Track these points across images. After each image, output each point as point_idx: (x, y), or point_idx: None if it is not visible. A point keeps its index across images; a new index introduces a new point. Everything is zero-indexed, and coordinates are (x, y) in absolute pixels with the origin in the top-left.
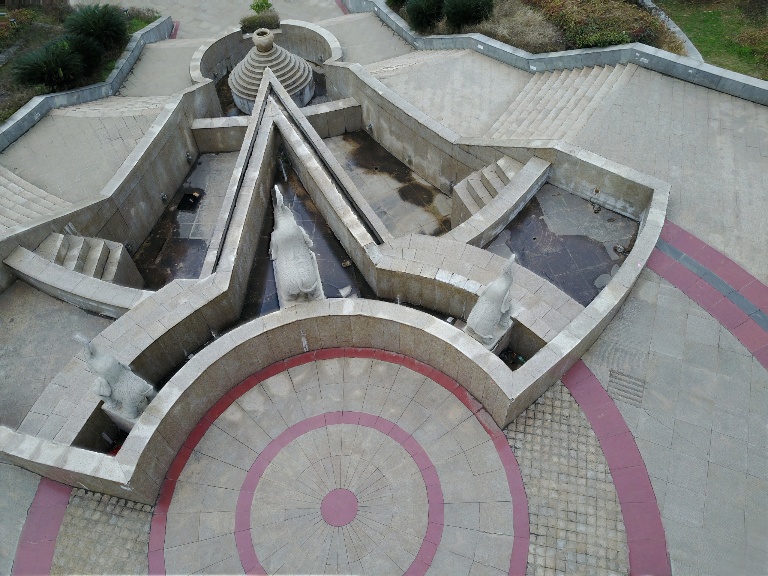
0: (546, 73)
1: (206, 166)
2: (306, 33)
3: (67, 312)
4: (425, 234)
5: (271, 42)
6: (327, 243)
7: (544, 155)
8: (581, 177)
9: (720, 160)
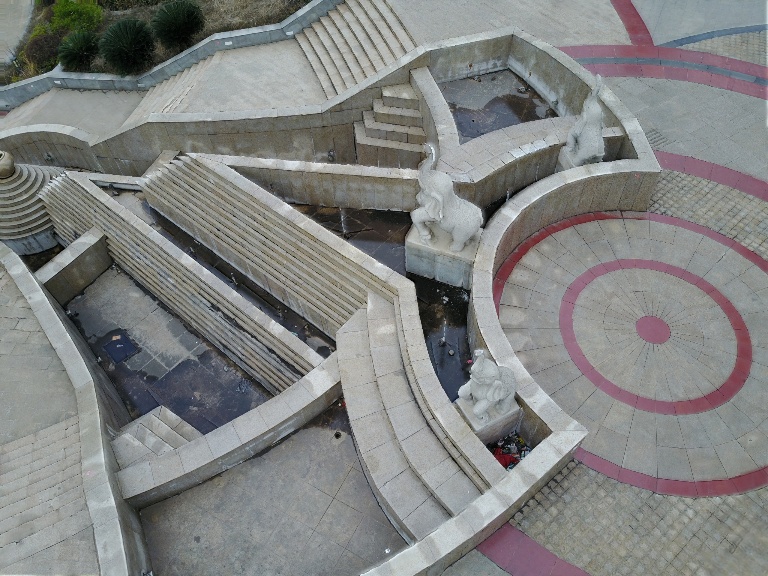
0: (306, 30)
1: (87, 311)
2: (15, 141)
3: (239, 476)
4: None
5: (12, 160)
6: (382, 220)
7: (419, 63)
8: (455, 62)
9: (506, 2)
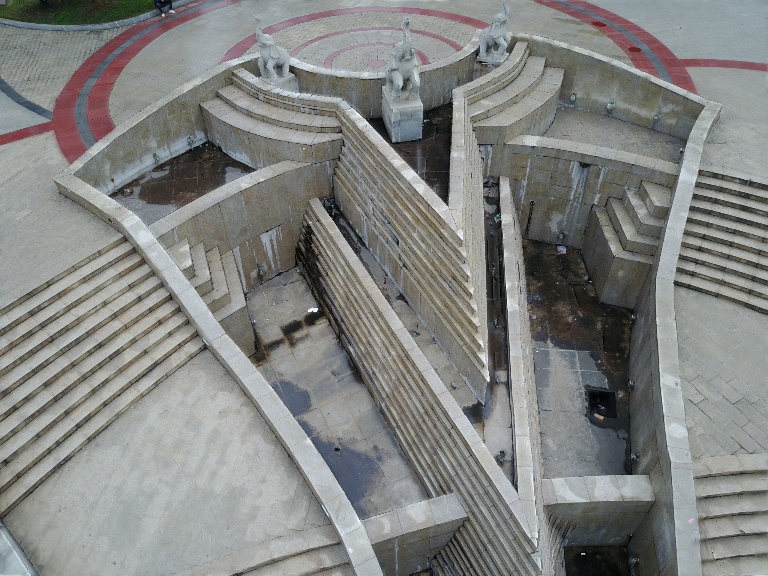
0: None
1: (609, 470)
2: None
3: None
4: (290, 343)
5: None
6: None
7: None
8: None
9: None
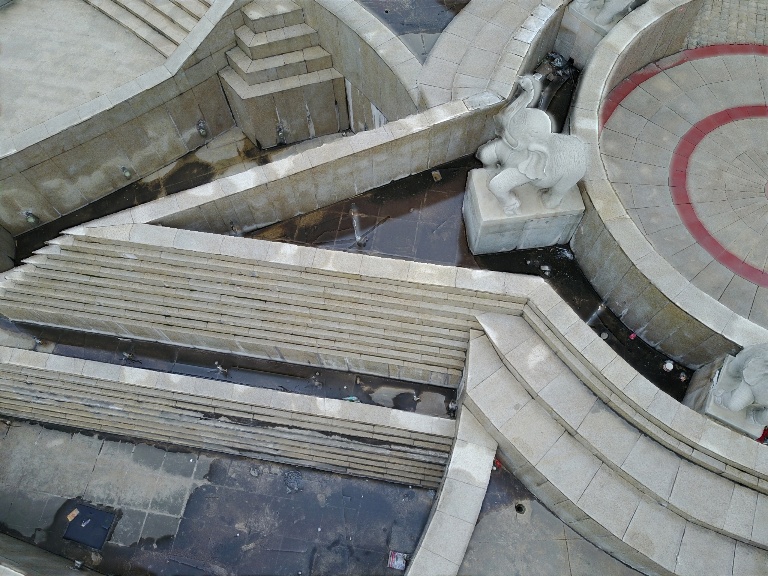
0: None
1: (1, 501)
2: None
3: None
4: None
5: None
6: (391, 199)
7: None
8: None
9: None
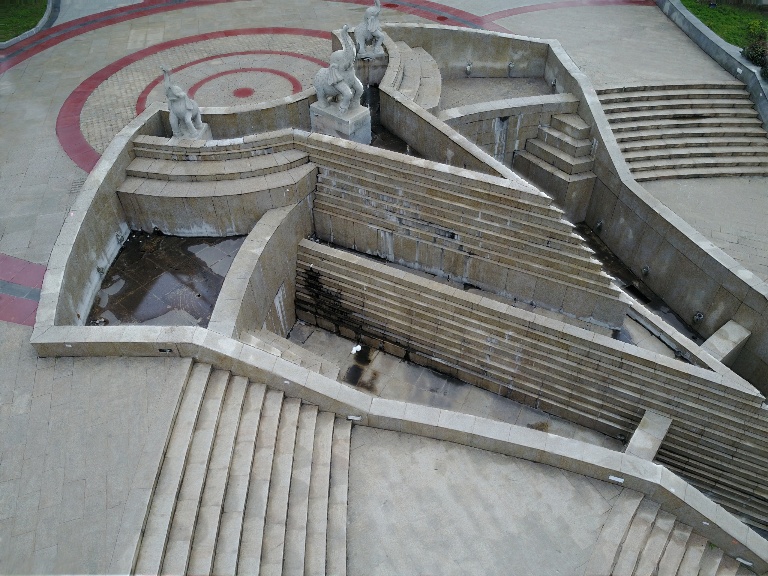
0: None
1: None
2: None
3: None
4: (368, 389)
5: None
6: None
7: None
8: None
9: None
